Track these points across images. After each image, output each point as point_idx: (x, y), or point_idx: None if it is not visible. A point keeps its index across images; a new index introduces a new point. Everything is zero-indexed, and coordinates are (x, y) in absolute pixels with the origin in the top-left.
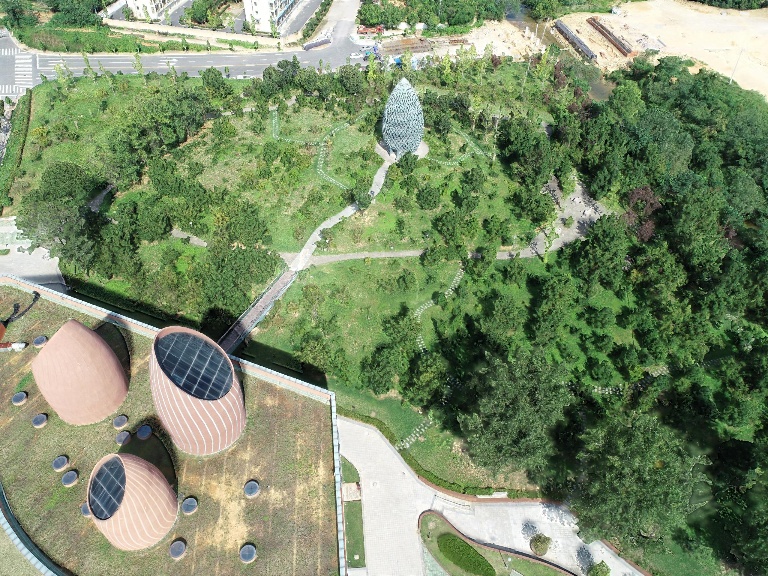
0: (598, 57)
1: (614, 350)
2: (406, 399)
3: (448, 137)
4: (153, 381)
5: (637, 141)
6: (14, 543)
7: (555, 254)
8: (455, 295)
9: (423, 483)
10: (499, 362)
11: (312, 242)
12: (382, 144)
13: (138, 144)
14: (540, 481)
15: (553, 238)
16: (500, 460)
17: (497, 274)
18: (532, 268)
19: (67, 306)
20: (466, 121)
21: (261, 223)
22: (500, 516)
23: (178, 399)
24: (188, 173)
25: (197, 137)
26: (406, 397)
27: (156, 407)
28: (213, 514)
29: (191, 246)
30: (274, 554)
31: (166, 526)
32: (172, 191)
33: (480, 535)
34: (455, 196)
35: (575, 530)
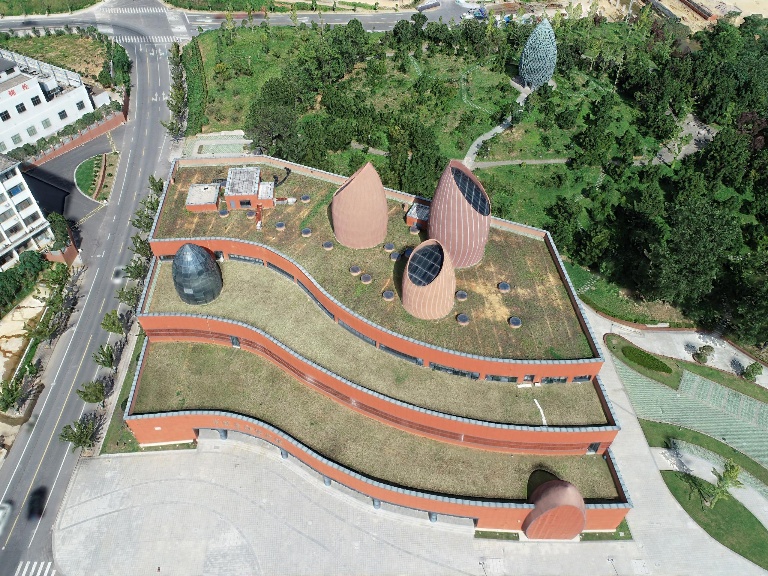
0: (680, 21)
1: (742, 228)
2: (575, 261)
3: (570, 76)
4: (445, 197)
5: (736, 80)
6: (346, 310)
7: (679, 162)
8: (601, 191)
9: (601, 316)
10: (679, 207)
11: (472, 152)
12: (515, 80)
13: (316, 74)
14: (693, 317)
15: (683, 145)
16: (681, 279)
17: (636, 174)
18: (662, 172)
19: (315, 177)
20: (583, 64)
21: (433, 134)
22: (665, 339)
23: (464, 210)
24: (353, 101)
25: (352, 74)
26: (575, 260)
27: (438, 222)
28: (480, 301)
29: (370, 155)
30: (533, 324)
31: (451, 304)
32: (346, 113)
33: (652, 350)
34: (588, 119)
35: (726, 349)
